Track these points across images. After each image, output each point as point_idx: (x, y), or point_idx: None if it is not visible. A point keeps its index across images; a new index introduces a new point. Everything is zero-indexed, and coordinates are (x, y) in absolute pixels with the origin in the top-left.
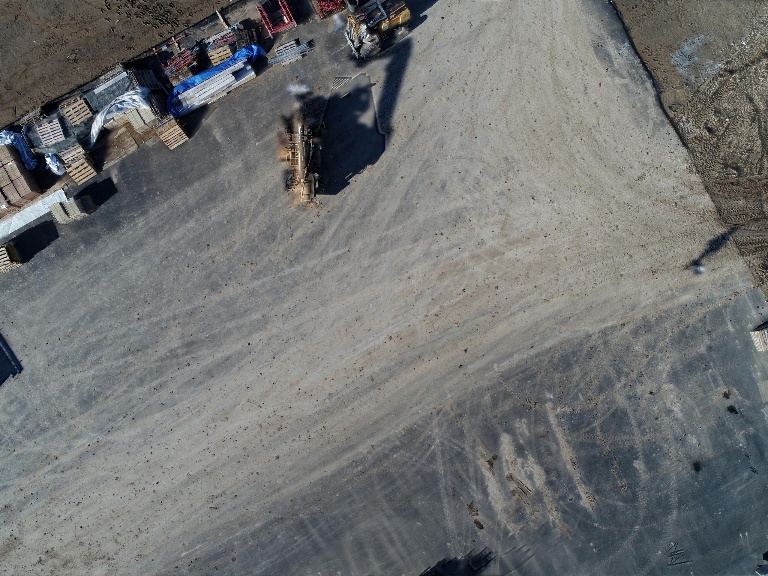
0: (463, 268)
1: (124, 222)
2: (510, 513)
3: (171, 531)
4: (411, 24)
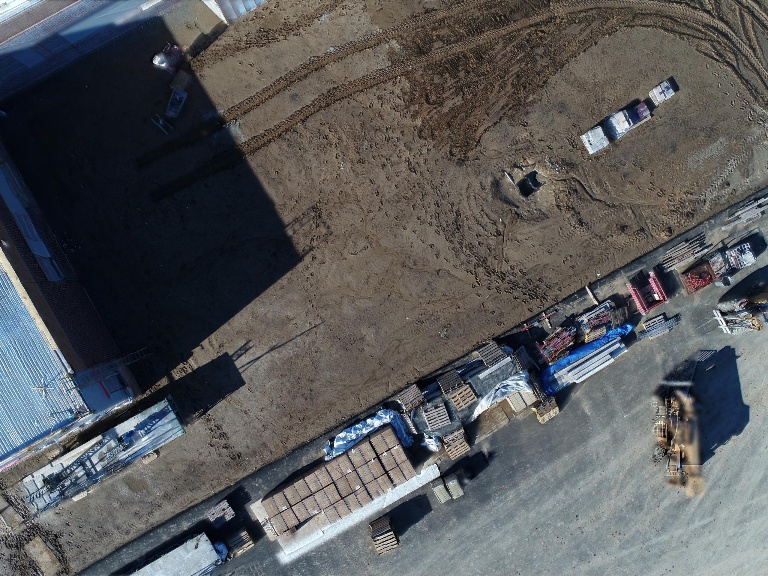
0: None
1: (495, 495)
2: None
3: None
4: None
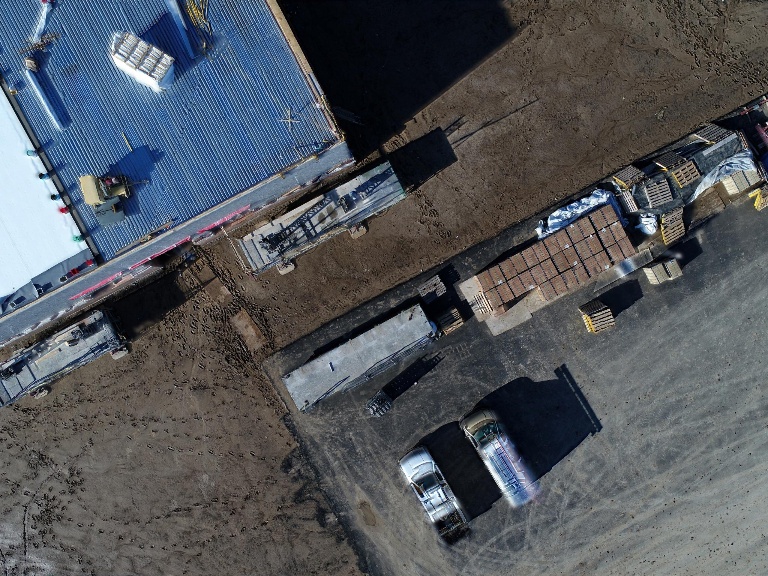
0: None
1: (708, 282)
2: None
3: None
4: None
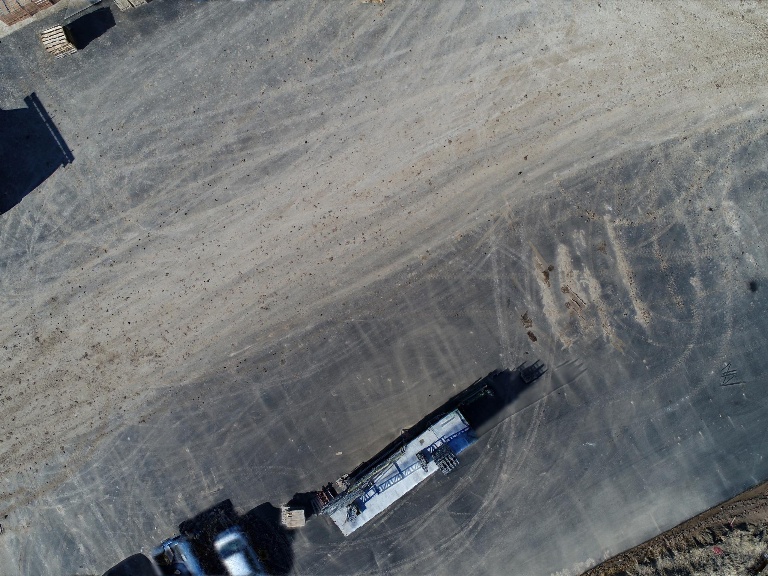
0: (526, 73)
1: (182, 12)
2: (564, 326)
3: (220, 330)
4: None
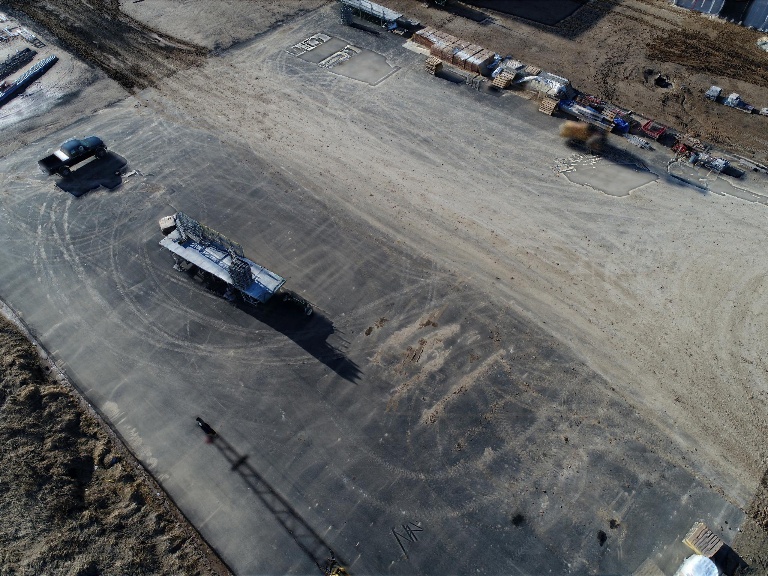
0: (574, 259)
1: (483, 103)
2: (389, 352)
3: (297, 159)
4: (712, 189)
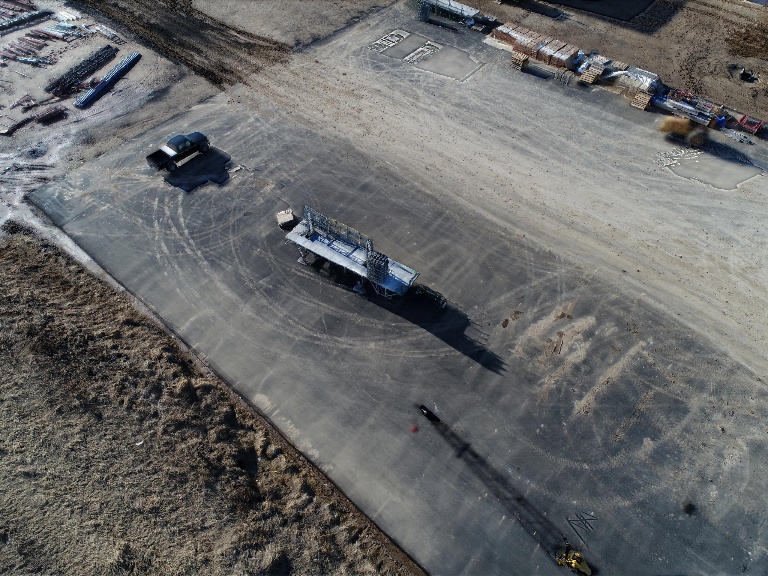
0: (696, 252)
1: (574, 98)
2: (530, 344)
3: (400, 154)
4: None
